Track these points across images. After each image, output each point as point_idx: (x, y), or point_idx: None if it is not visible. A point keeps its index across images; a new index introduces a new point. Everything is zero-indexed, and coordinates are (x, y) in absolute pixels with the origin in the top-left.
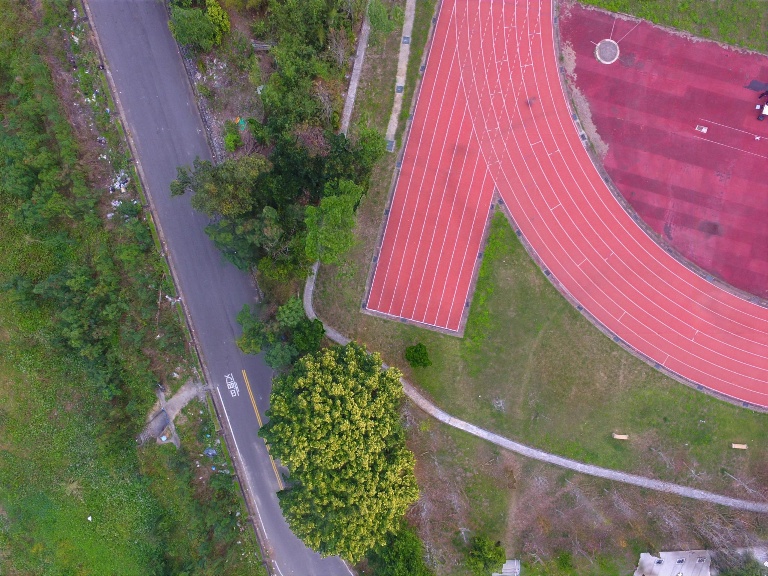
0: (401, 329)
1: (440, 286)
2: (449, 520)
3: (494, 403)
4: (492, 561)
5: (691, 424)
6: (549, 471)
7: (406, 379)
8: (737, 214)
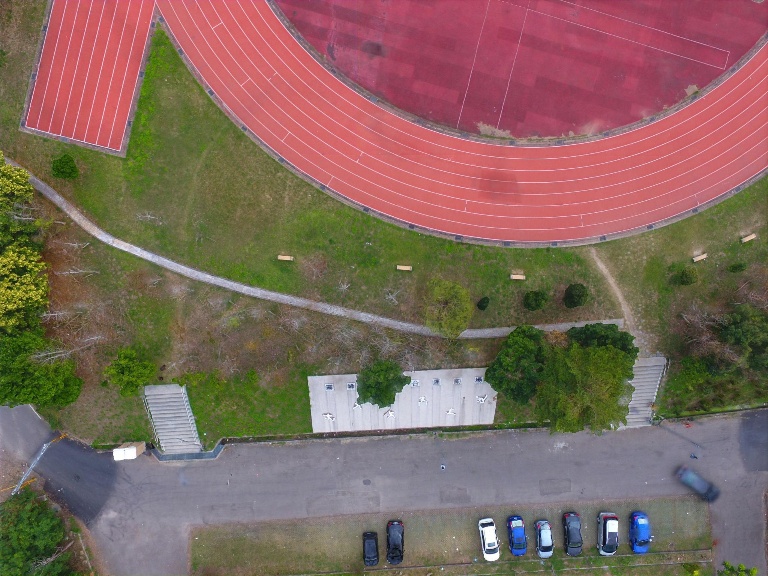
0: (61, 148)
1: (101, 104)
2: (114, 344)
3: (138, 213)
4: (132, 371)
5: (357, 246)
6: (214, 293)
7: (68, 200)
8: (400, 35)
